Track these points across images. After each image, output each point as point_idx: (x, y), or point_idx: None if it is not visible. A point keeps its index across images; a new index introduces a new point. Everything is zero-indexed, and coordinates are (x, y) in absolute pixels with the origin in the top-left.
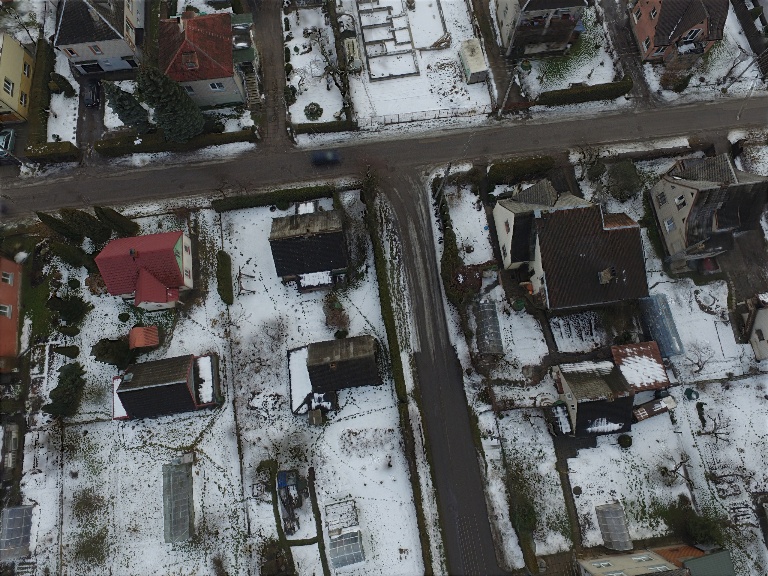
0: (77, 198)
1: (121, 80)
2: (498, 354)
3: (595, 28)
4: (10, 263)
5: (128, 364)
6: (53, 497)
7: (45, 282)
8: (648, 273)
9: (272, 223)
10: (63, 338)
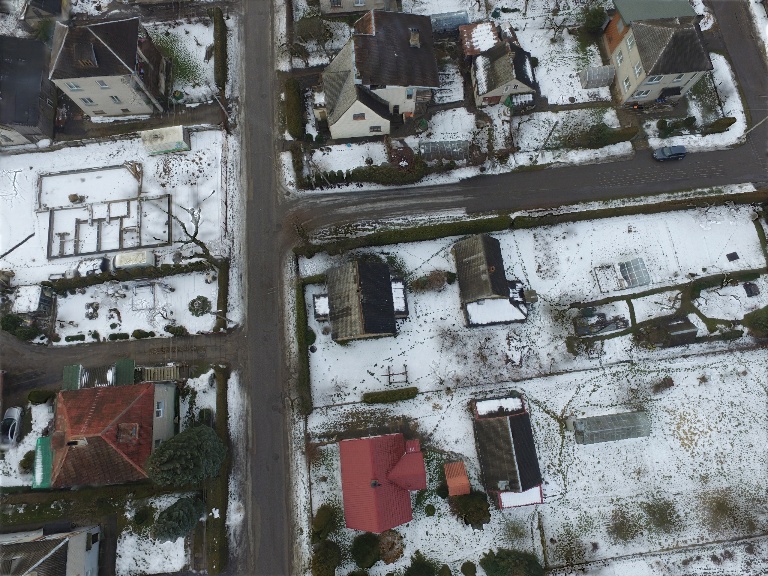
0: None
1: (115, 555)
2: None
3: None
4: None
5: None
6: (618, 568)
7: None
8: None
9: None
10: None
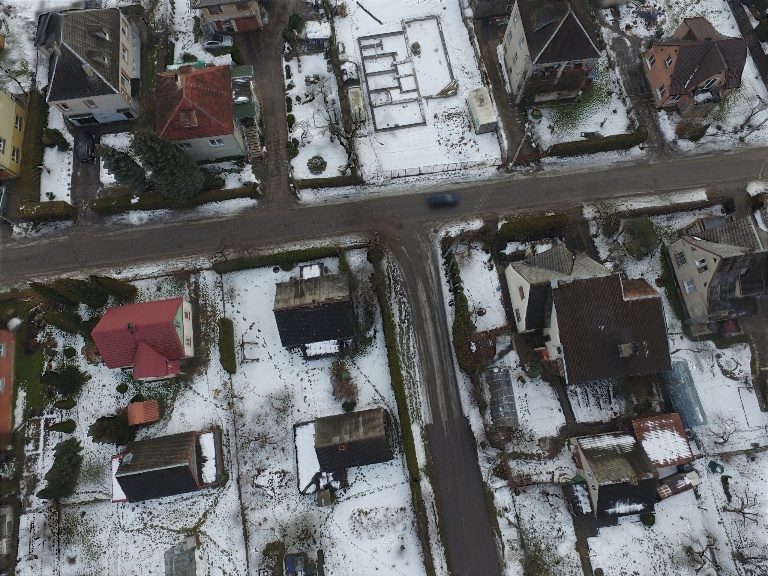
0: (72, 259)
1: (117, 132)
2: (513, 426)
3: (607, 73)
4: (3, 333)
5: (127, 440)
6: None
7: (40, 350)
8: None
9: (276, 289)
10: (59, 411)
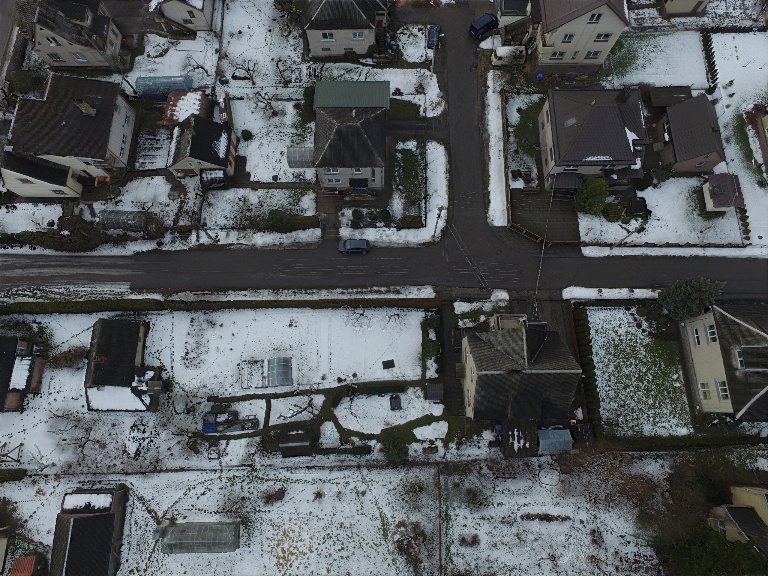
0: None
1: None
2: None
3: None
4: None
5: None
6: None
7: None
8: (122, 86)
9: None
10: None
